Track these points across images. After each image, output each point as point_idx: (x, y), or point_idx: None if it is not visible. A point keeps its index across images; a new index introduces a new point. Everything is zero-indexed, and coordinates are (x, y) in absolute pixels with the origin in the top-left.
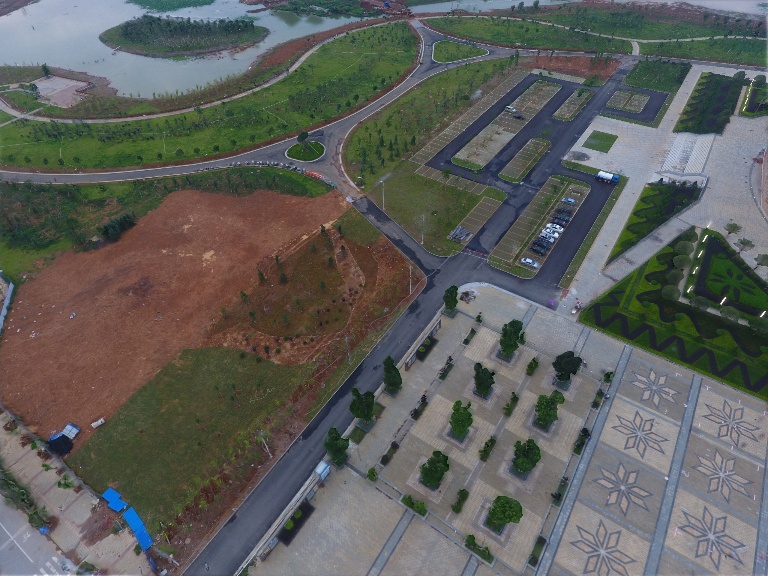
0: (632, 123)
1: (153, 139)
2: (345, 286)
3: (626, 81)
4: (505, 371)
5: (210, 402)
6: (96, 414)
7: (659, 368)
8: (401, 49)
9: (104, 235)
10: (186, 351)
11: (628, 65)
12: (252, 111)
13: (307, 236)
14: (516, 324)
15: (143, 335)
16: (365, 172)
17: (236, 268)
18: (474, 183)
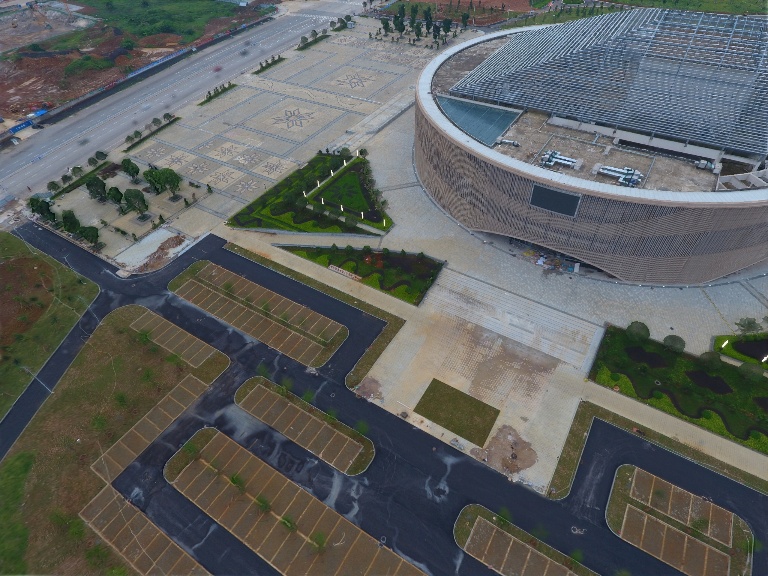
0: None
1: None
2: None
3: None
4: None
5: None
6: None
7: None
8: None
9: None
10: (435, 3)
11: None
12: None
13: (501, 8)
14: None
15: None
16: None
17: None
18: None
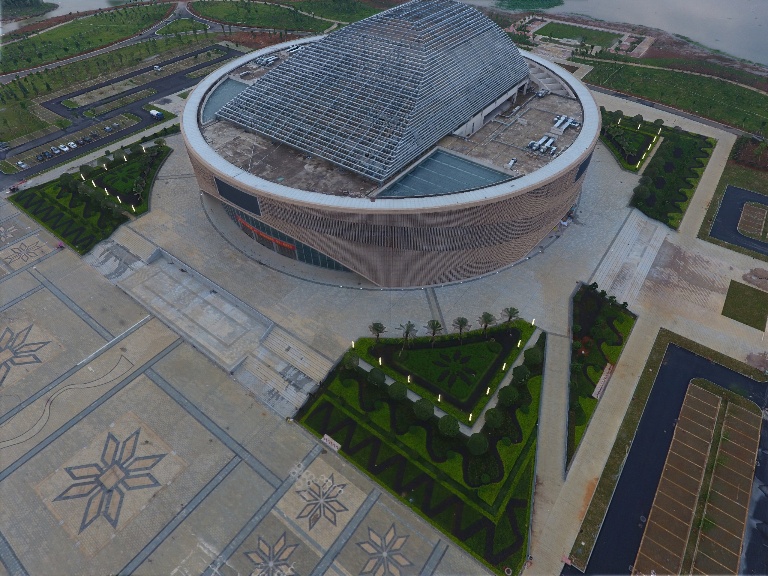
0: None
1: None
2: None
3: None
4: None
5: None
6: None
7: (21, 224)
8: (136, 23)
9: None
10: None
11: None
12: None
13: None
14: None
15: None
16: None
17: None
18: (57, 116)
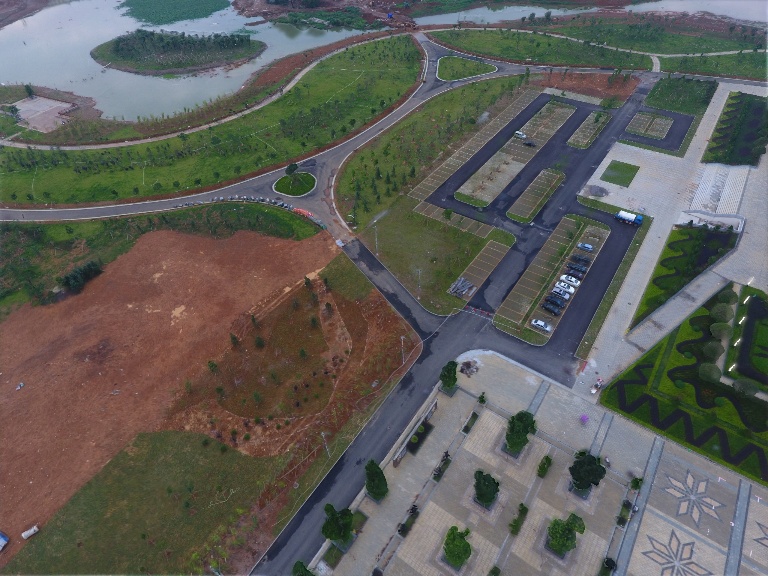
0: (655, 151)
1: (132, 169)
2: (329, 352)
3: (647, 102)
4: (512, 471)
5: (163, 505)
6: (30, 519)
7: (697, 470)
8: (403, 66)
9: (65, 286)
10: (142, 435)
11: (648, 83)
12: (240, 137)
13: (290, 288)
14: (525, 417)
15: (95, 413)
16: (358, 209)
17: (208, 328)
18: (479, 223)
